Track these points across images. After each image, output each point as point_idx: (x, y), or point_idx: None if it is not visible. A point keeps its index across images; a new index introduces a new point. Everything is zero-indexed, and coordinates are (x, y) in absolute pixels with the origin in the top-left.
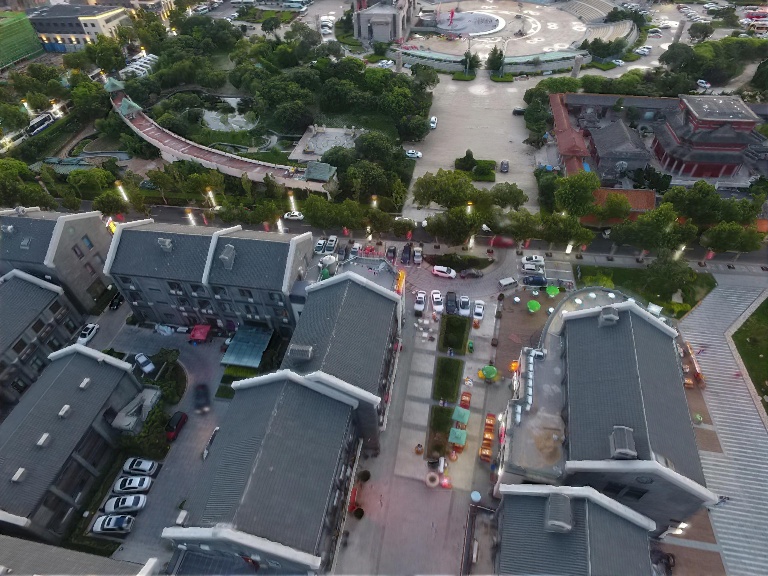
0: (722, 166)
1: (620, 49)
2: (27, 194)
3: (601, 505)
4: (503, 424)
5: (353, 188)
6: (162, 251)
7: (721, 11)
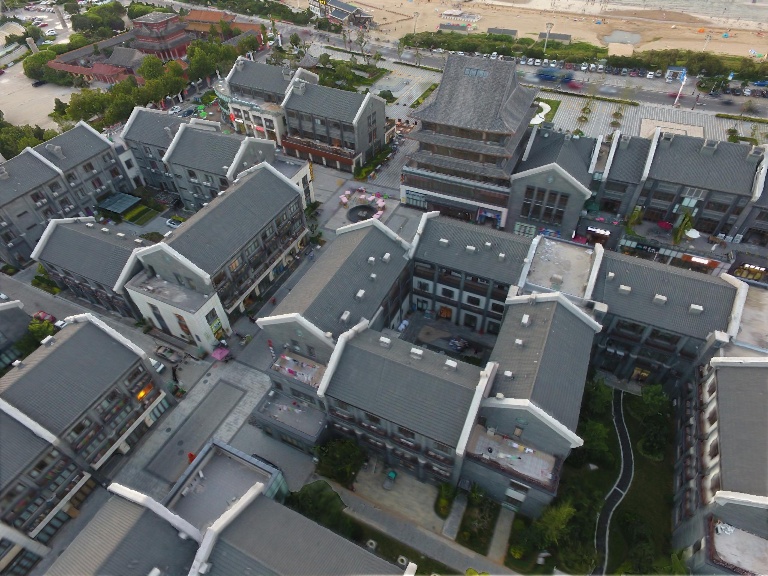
0: (185, 46)
1: (38, 34)
2: None
3: None
4: (256, 126)
5: (30, 135)
6: (2, 181)
7: (61, 0)
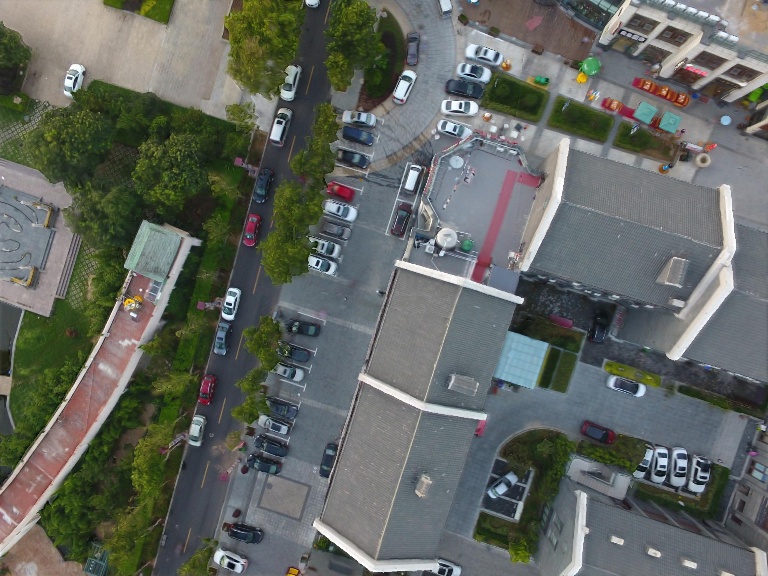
0: None
1: None
2: None
3: None
4: (690, 65)
5: (227, 193)
6: None
7: None
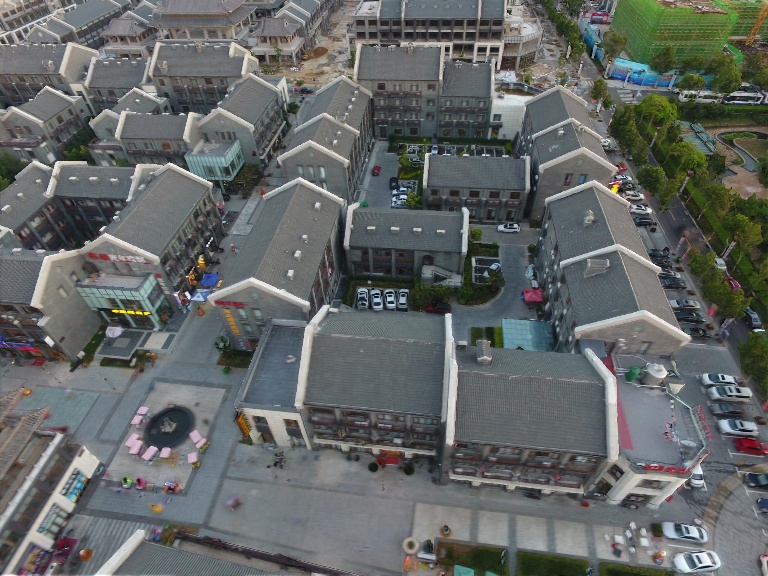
0: None
1: None
2: (626, 130)
3: None
4: None
5: None
6: (583, 221)
7: None
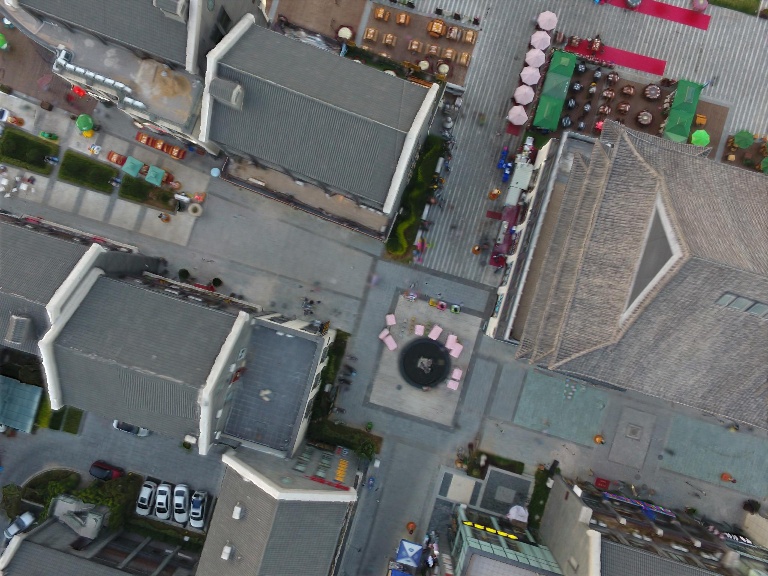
0: None
1: None
2: None
3: (226, 52)
4: (146, 124)
5: None
6: None
7: None
